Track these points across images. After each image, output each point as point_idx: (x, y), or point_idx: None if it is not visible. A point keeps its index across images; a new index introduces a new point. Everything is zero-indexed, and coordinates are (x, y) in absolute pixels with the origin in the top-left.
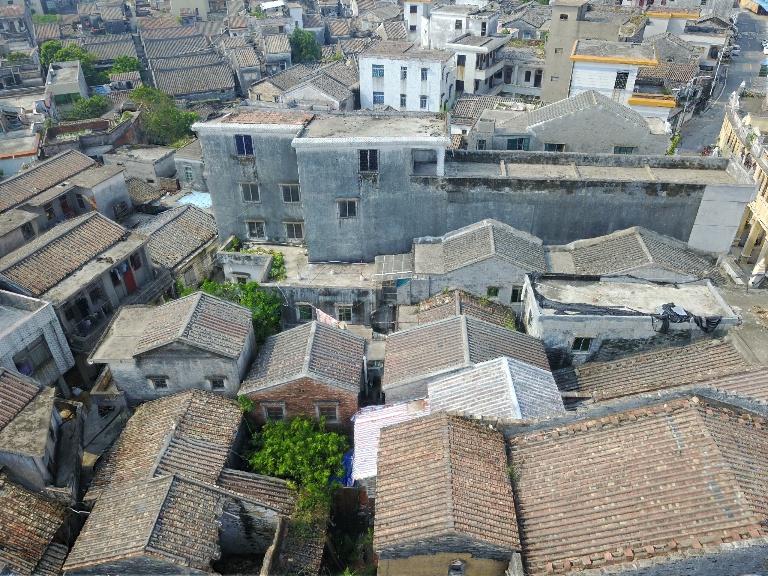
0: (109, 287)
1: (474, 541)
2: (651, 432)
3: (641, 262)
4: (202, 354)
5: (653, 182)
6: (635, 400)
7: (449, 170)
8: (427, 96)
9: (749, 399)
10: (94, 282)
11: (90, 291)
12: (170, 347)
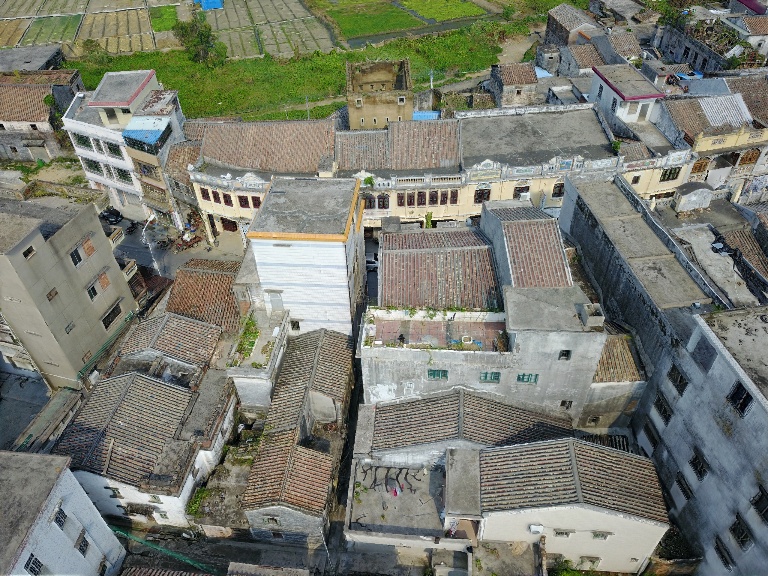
0: None
1: None
2: None
3: (689, 252)
4: None
5: (653, 213)
6: None
7: (701, 349)
8: (83, 531)
9: None
10: None
11: None
12: None
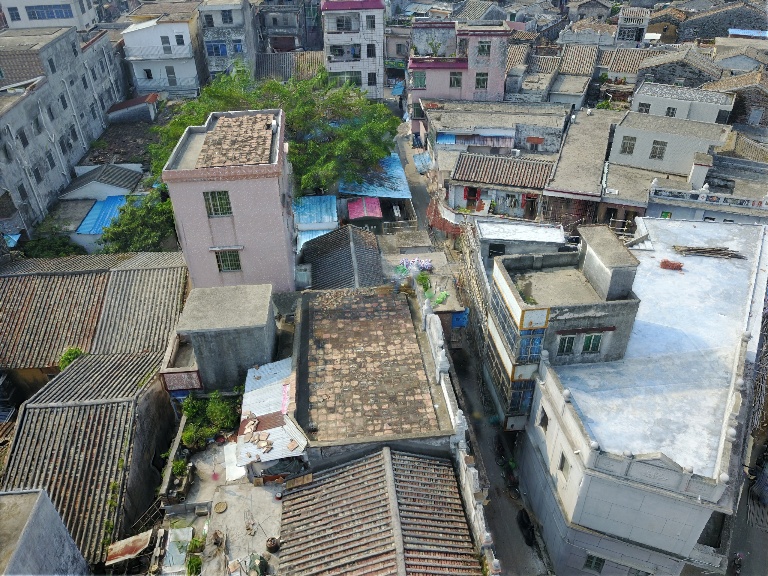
0: (558, 6)
1: (672, 18)
2: (727, 8)
3: None
4: (599, 6)
5: None
6: (726, 4)
7: None
8: None
9: (759, 5)
10: (555, 2)
11: (554, 4)
12: (591, 2)
